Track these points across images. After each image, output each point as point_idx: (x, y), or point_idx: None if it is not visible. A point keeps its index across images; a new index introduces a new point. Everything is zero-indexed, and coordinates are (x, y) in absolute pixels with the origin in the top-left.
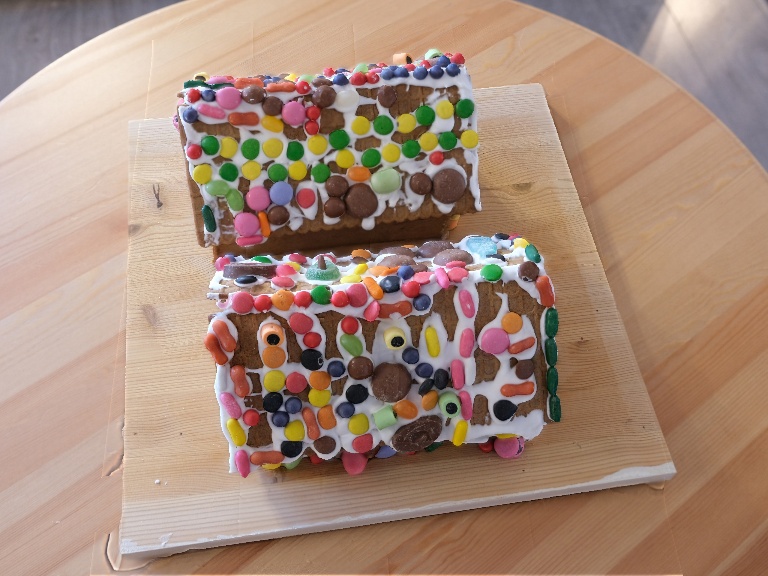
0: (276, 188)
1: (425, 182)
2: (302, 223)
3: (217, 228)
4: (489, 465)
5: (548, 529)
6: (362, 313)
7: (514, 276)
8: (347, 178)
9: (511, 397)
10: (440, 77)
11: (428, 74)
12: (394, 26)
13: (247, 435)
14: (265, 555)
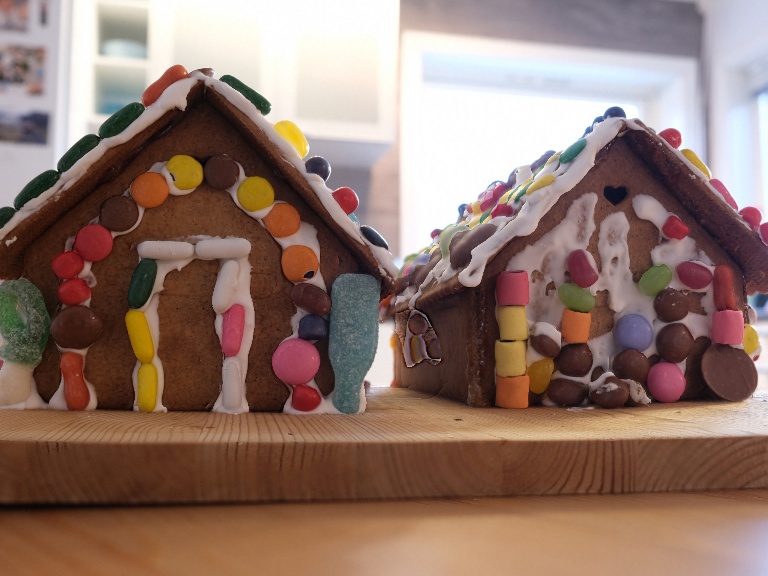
0: None
1: (462, 233)
2: None
3: None
4: None
5: None
6: None
7: None
8: None
9: None
10: None
11: None
12: None
13: None
14: None
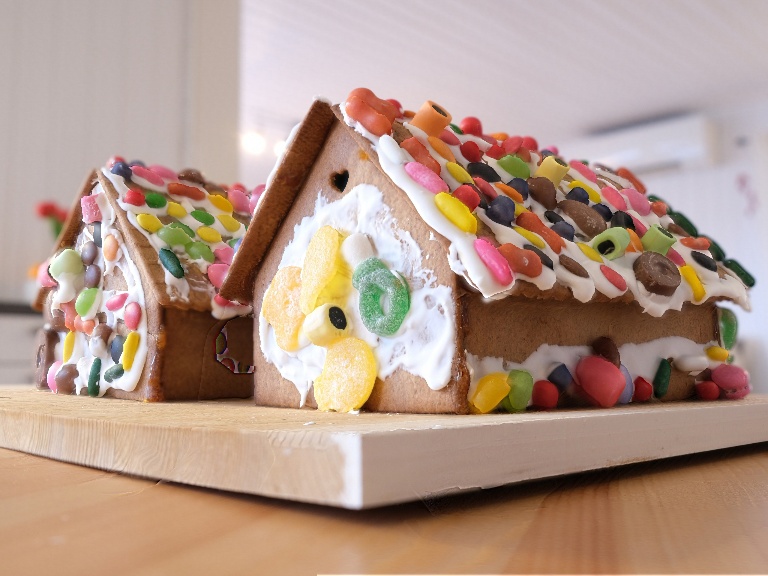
0: None
1: None
2: None
3: (184, 279)
4: (737, 401)
5: None
6: None
7: (596, 170)
8: None
9: (697, 250)
10: None
11: None
12: None
13: None
14: None
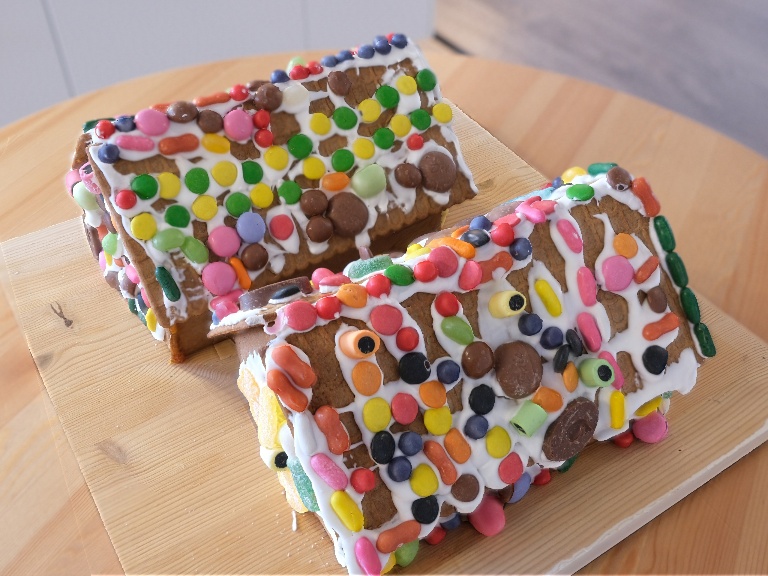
0: (244, 220)
1: (414, 170)
2: (284, 262)
3: (181, 295)
4: (639, 460)
5: (739, 511)
6: (456, 284)
7: (606, 189)
8: (323, 190)
9: (657, 340)
10: (389, 52)
11: (375, 51)
12: None
13: (361, 512)
14: None
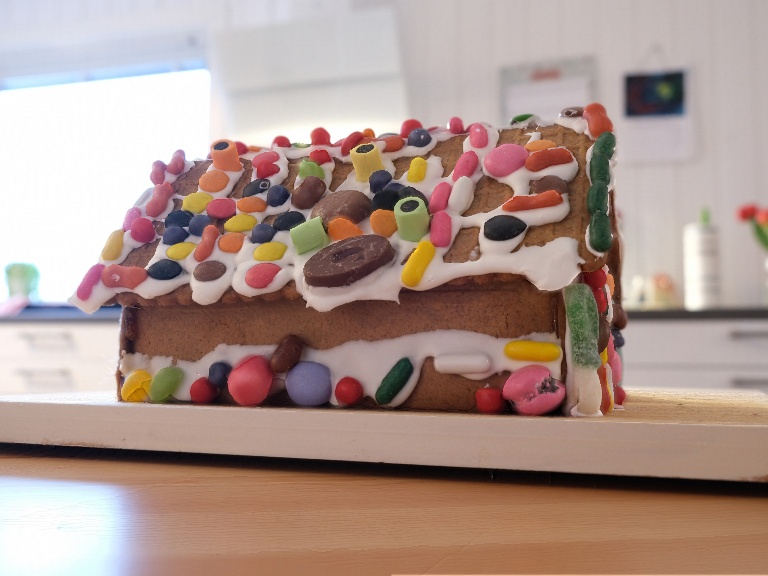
0: None
1: None
2: None
3: None
4: None
5: (581, 500)
6: (340, 151)
7: None
8: None
9: (518, 212)
10: None
11: None
12: None
13: (123, 256)
14: (11, 459)
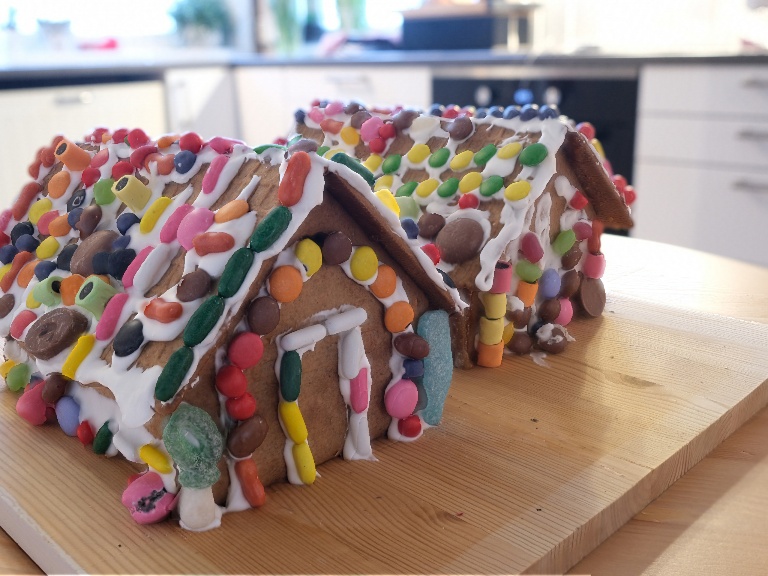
0: None
1: (431, 219)
2: None
3: None
4: (110, 511)
5: None
6: None
7: None
8: None
9: (149, 320)
10: (529, 120)
11: (519, 116)
12: (691, 279)
13: None
14: None
